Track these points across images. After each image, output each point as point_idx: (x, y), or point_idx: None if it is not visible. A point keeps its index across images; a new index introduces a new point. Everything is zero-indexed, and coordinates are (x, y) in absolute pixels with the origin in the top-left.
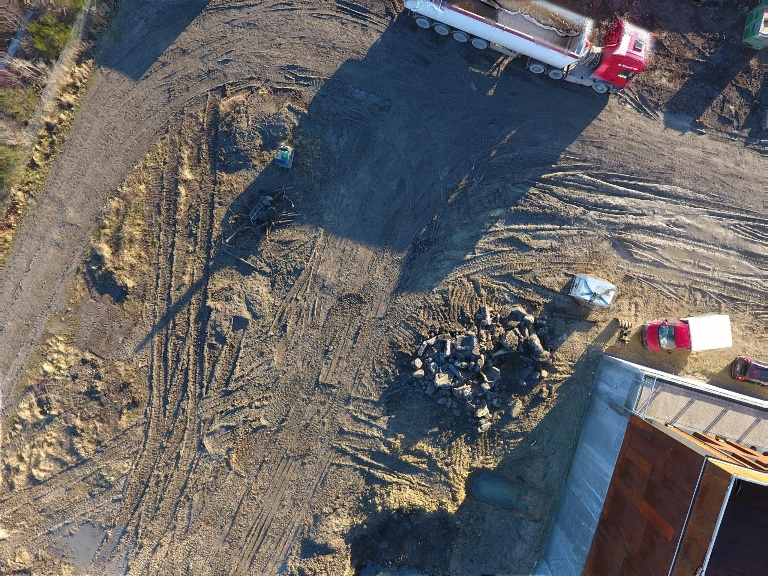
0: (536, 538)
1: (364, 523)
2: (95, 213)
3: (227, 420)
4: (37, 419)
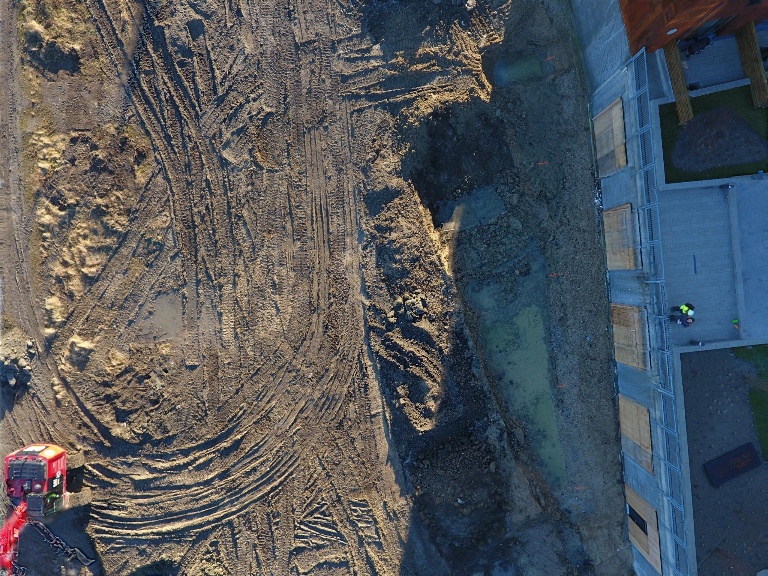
0: (576, 86)
1: (411, 149)
2: (9, 0)
3: (234, 126)
4: (60, 218)
